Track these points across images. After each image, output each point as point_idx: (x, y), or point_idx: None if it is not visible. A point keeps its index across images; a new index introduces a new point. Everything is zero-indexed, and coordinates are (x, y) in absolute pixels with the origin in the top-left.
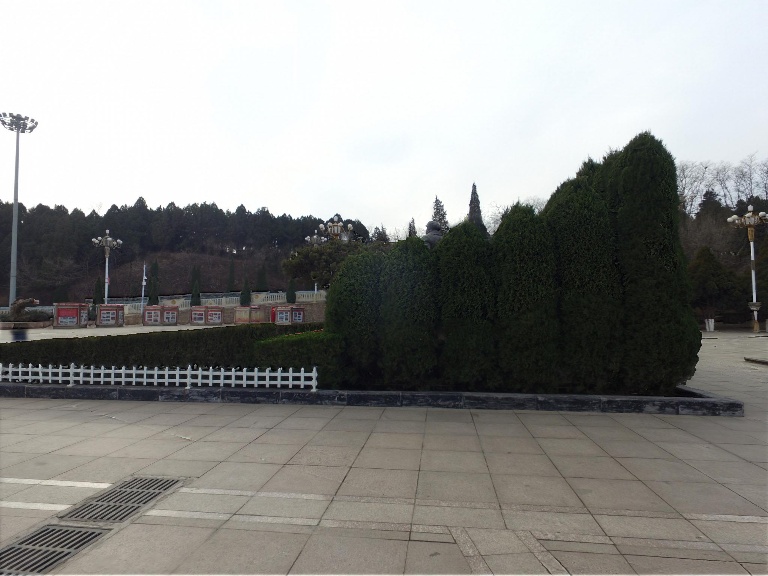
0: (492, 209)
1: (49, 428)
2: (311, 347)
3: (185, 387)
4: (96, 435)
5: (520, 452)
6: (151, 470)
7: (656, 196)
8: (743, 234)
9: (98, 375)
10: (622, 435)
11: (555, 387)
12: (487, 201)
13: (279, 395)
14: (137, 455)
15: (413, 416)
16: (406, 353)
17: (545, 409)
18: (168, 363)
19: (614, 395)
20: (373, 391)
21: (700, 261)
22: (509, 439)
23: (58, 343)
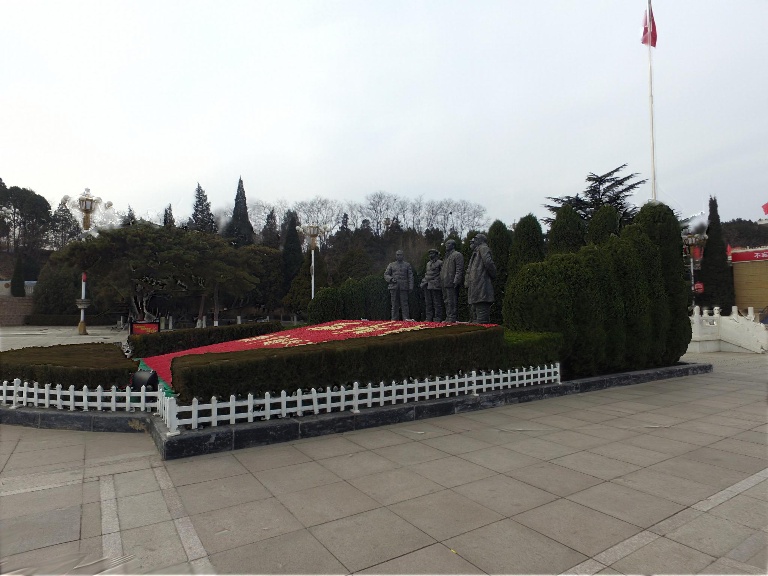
0: (258, 208)
1: (549, 447)
2: (548, 345)
3: (473, 394)
4: (609, 440)
5: (766, 398)
6: (764, 442)
7: (680, 244)
8: None
9: (386, 393)
10: (740, 385)
11: (643, 365)
12: (253, 199)
13: (543, 391)
14: (708, 440)
15: (643, 392)
16: (598, 346)
17: (660, 379)
18: (436, 371)
19: (671, 366)
20: (584, 379)
21: None
22: (732, 394)
23: (312, 357)
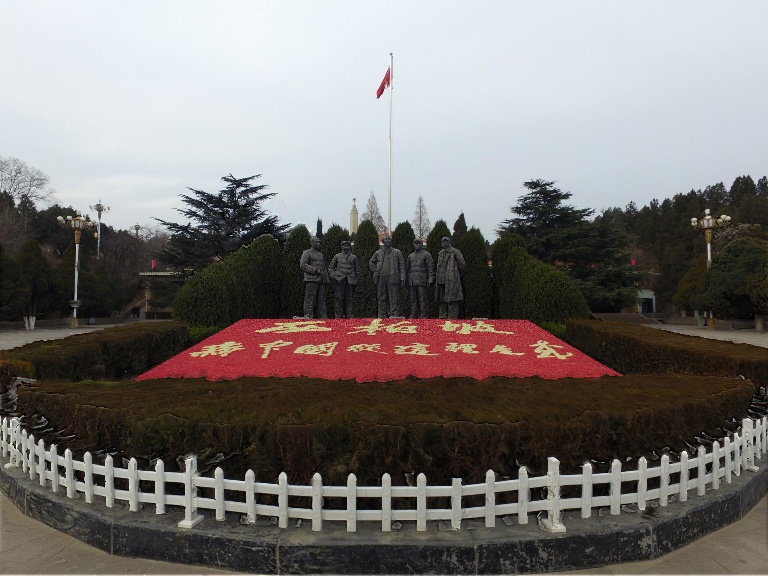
0: None
1: None
2: None
3: None
4: None
5: None
6: None
7: None
8: (69, 235)
9: None
10: None
11: None
12: None
13: None
14: None
15: None
16: None
17: None
18: None
19: None
20: None
21: (30, 255)
22: None
23: None
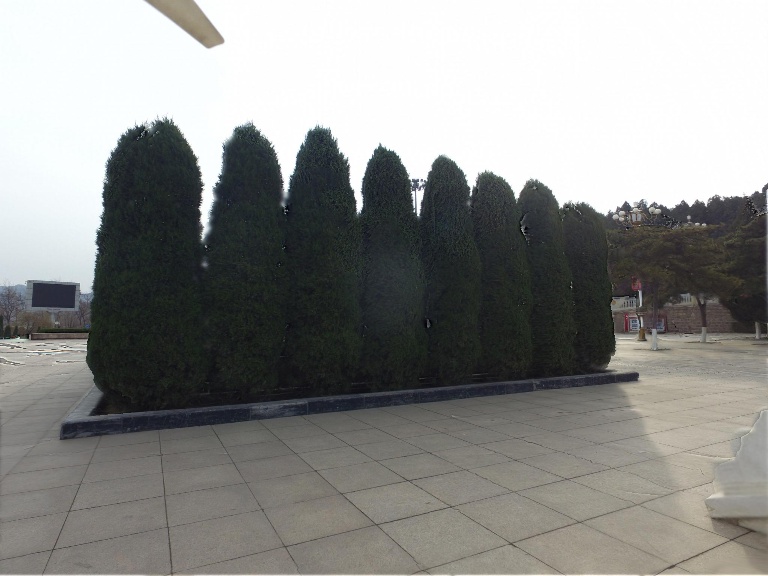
0: None
1: None
2: None
3: None
4: None
5: None
6: None
7: None
8: None
9: None
10: None
11: None
12: None
13: None
14: None
15: None
16: None
17: None
18: None
19: None
20: None
21: None
22: None
23: None
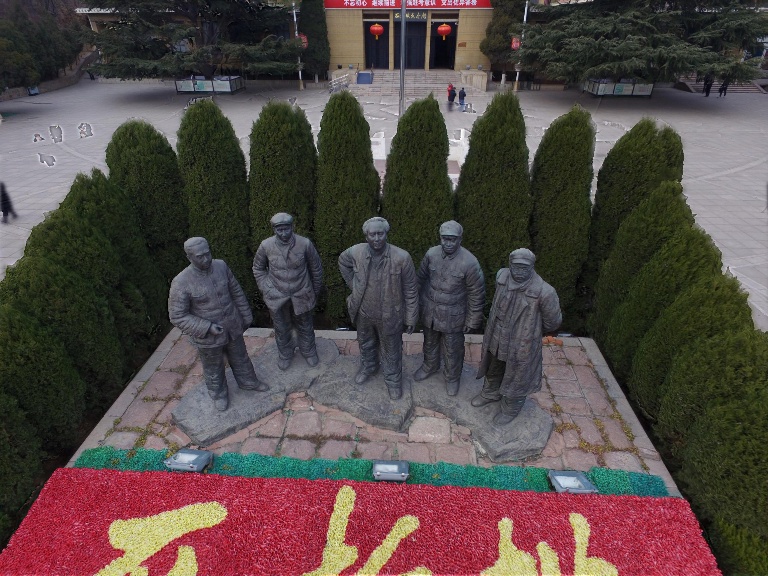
0: None
1: None
2: None
3: None
4: None
5: None
6: None
7: None
8: None
9: None
10: None
11: None
12: None
13: None
14: None
15: None
16: None
17: None
18: None
19: None
20: None
21: None
22: None
23: None
